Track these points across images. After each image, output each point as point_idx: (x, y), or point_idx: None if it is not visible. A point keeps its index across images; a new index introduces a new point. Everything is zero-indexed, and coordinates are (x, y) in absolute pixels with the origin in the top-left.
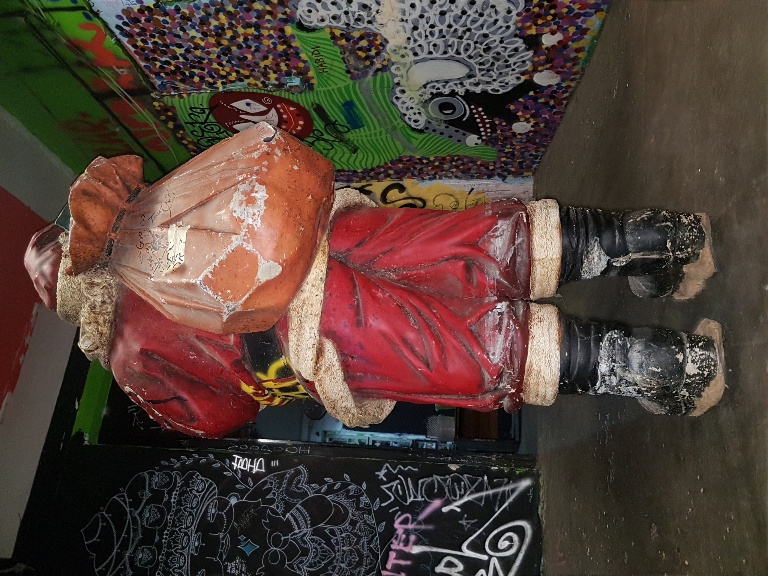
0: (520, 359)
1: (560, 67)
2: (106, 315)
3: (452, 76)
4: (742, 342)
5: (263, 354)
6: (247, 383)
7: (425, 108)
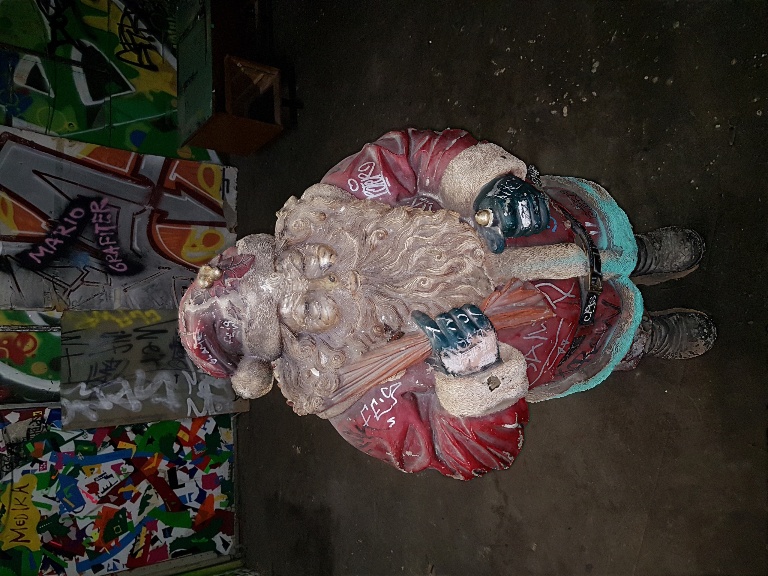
0: None
1: None
2: None
3: None
4: None
5: None
6: None
7: None
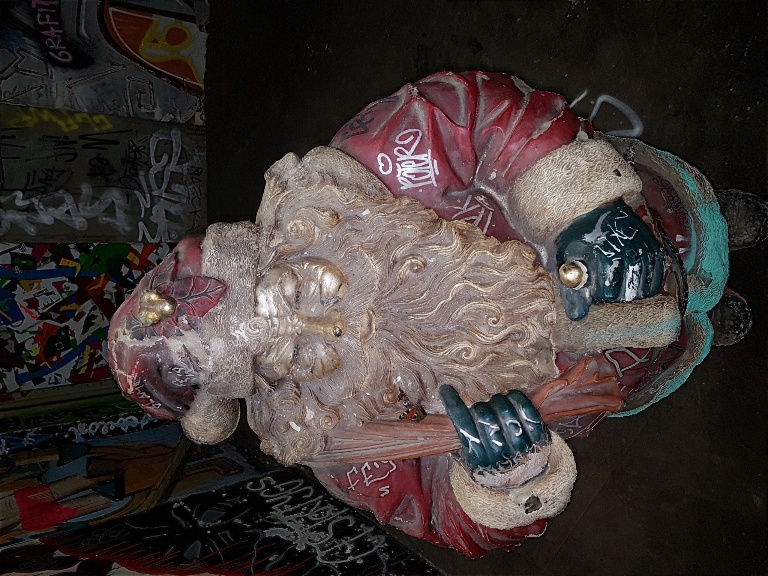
0: None
1: None
2: None
3: None
4: None
5: None
6: None
7: None
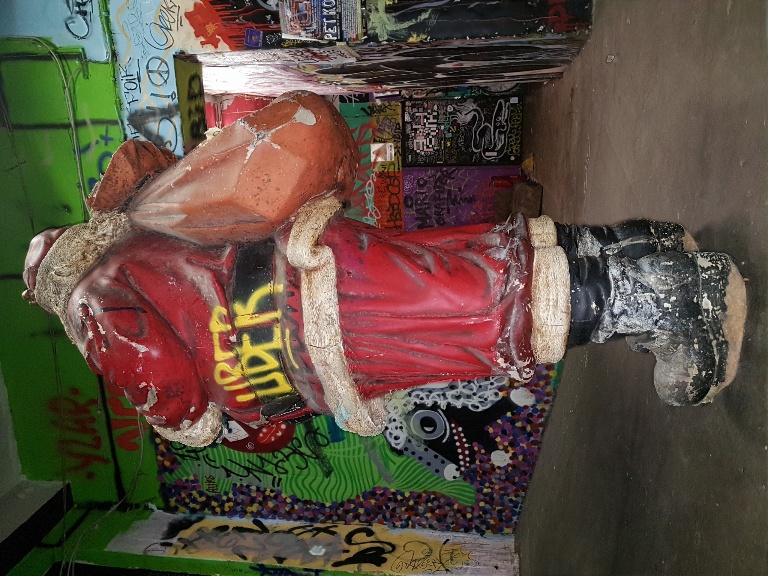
0: (527, 253)
1: (534, 385)
2: (99, 246)
3: (436, 385)
4: (744, 244)
5: (251, 278)
6: (222, 303)
7: (407, 421)
